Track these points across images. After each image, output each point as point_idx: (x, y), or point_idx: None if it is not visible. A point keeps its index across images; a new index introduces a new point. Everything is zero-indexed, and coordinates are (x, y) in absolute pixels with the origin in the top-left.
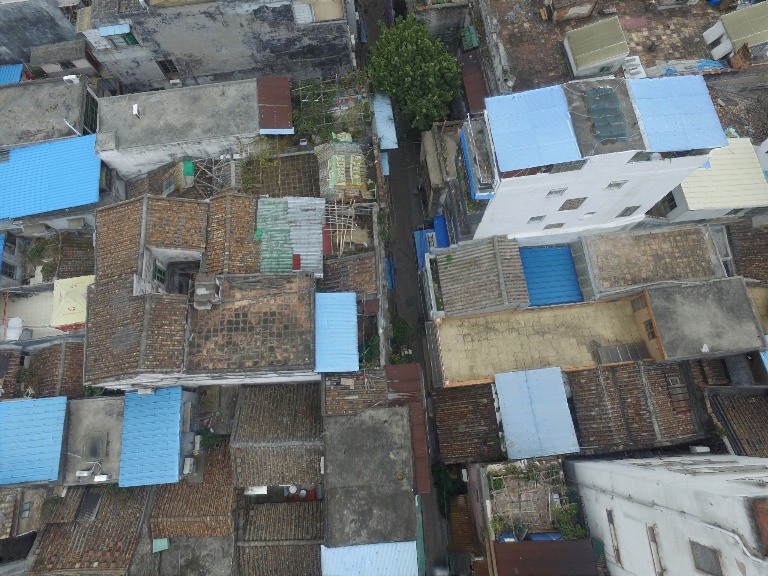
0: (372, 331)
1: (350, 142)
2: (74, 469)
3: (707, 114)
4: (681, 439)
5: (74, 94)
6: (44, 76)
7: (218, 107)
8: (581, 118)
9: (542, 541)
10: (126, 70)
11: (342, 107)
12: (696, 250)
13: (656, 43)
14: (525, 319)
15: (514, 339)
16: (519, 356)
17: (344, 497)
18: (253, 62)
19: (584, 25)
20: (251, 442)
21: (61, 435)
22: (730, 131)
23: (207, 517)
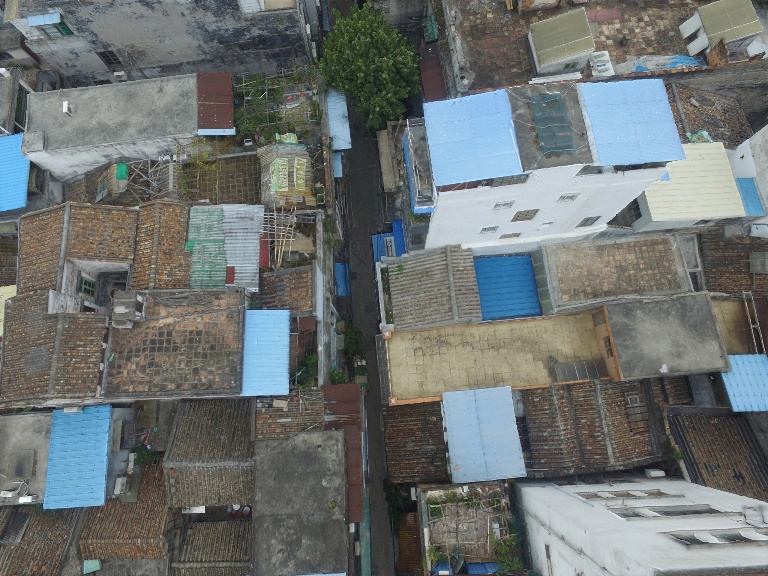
0: (313, 347)
1: (295, 144)
2: None
3: (664, 123)
4: (636, 462)
5: (5, 89)
6: None
7: (155, 105)
8: (525, 127)
9: (476, 575)
10: (65, 61)
11: (293, 104)
12: (662, 261)
13: (627, 37)
14: (480, 332)
15: (467, 354)
16: (472, 372)
17: (272, 526)
18: (201, 53)
19: (551, 16)
20: (185, 462)
21: None
22: (702, 134)
23: (138, 539)
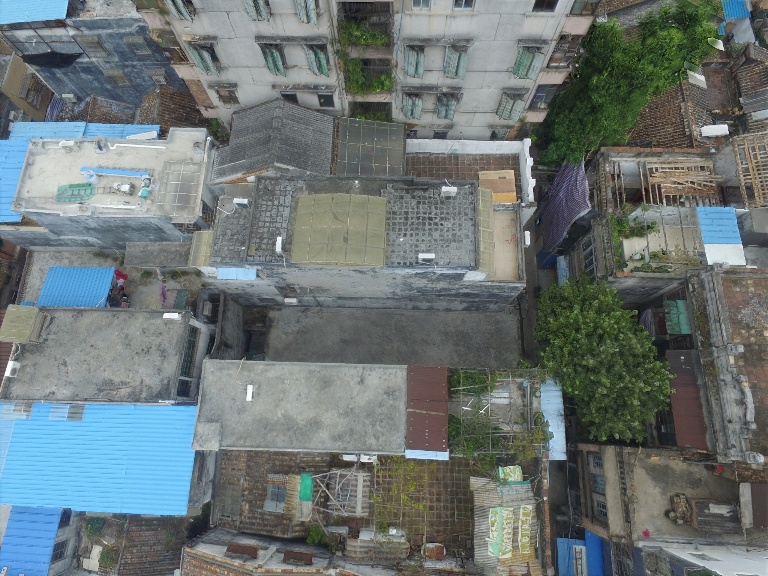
0: None
1: (520, 482)
2: None
3: None
4: None
5: (173, 335)
6: None
7: (354, 401)
8: None
9: None
10: (236, 287)
11: (501, 392)
12: None
13: None
14: None
15: None
16: None
17: None
18: (391, 294)
19: None
20: None
21: None
22: None
23: None
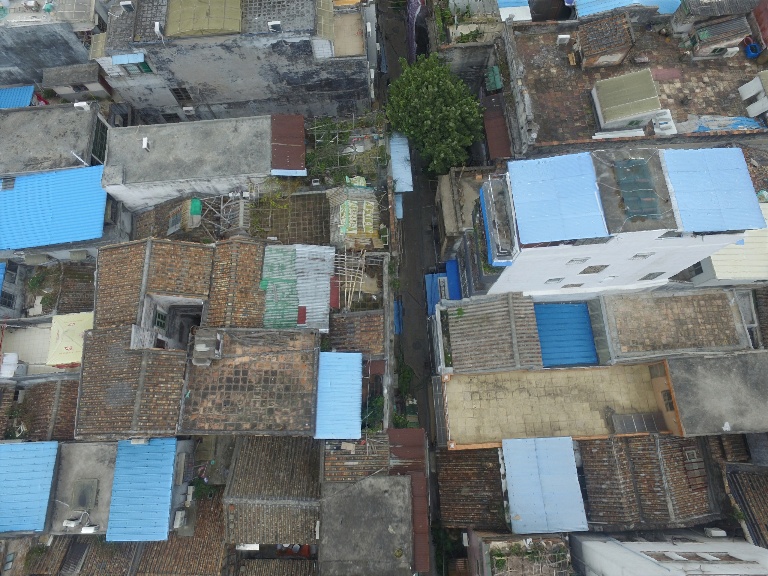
0: (377, 388)
1: (364, 187)
2: (62, 517)
3: (745, 191)
4: (696, 520)
5: (84, 121)
6: (56, 96)
7: (230, 144)
8: (610, 191)
9: None
10: (139, 96)
11: (357, 146)
12: (720, 317)
13: (689, 97)
14: (537, 379)
15: (524, 400)
16: (528, 419)
17: (338, 571)
18: (269, 93)
19: (614, 73)
20: (245, 498)
21: (50, 482)
22: (763, 194)
23: (195, 575)
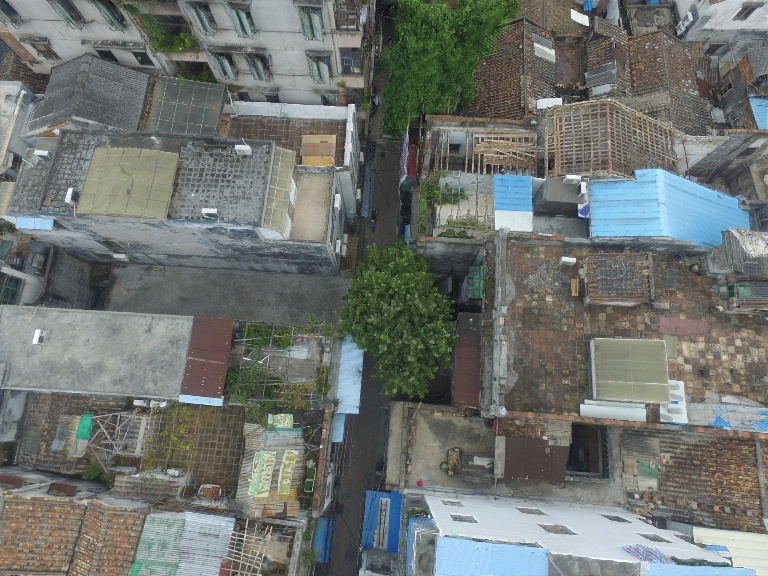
0: None
1: (289, 429)
2: None
3: None
4: None
5: None
6: None
7: (138, 348)
8: None
9: None
10: (61, 240)
11: (301, 348)
12: None
13: (711, 373)
14: None
15: None
16: None
17: None
18: (213, 253)
19: (623, 317)
20: None
21: None
22: None
23: None
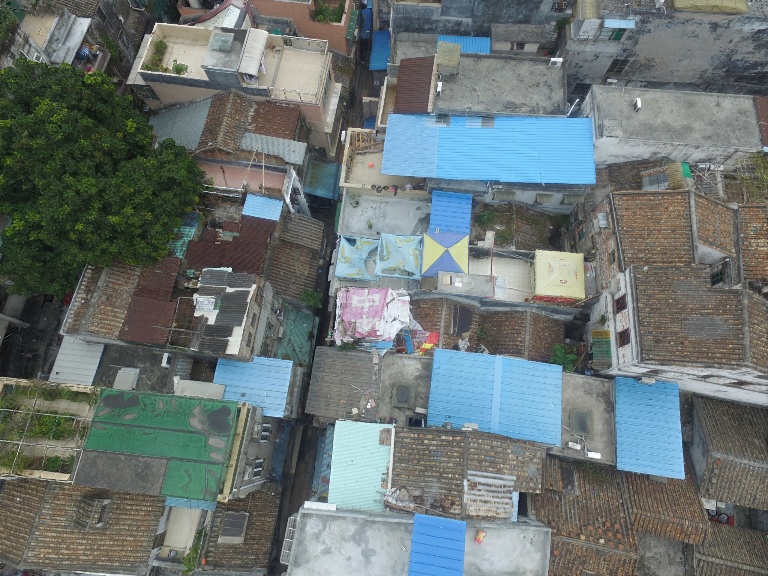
0: None
1: None
2: None
3: None
4: None
5: (555, 76)
6: None
7: (715, 116)
8: None
9: None
10: (578, 62)
11: None
12: None
13: None
14: None
15: None
16: None
17: None
18: (697, 77)
19: None
20: (732, 456)
21: (561, 403)
22: None
23: (686, 521)
